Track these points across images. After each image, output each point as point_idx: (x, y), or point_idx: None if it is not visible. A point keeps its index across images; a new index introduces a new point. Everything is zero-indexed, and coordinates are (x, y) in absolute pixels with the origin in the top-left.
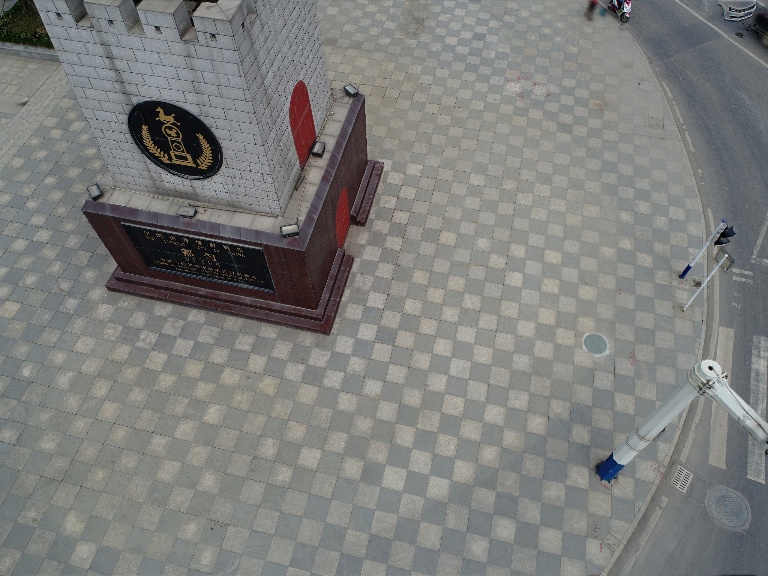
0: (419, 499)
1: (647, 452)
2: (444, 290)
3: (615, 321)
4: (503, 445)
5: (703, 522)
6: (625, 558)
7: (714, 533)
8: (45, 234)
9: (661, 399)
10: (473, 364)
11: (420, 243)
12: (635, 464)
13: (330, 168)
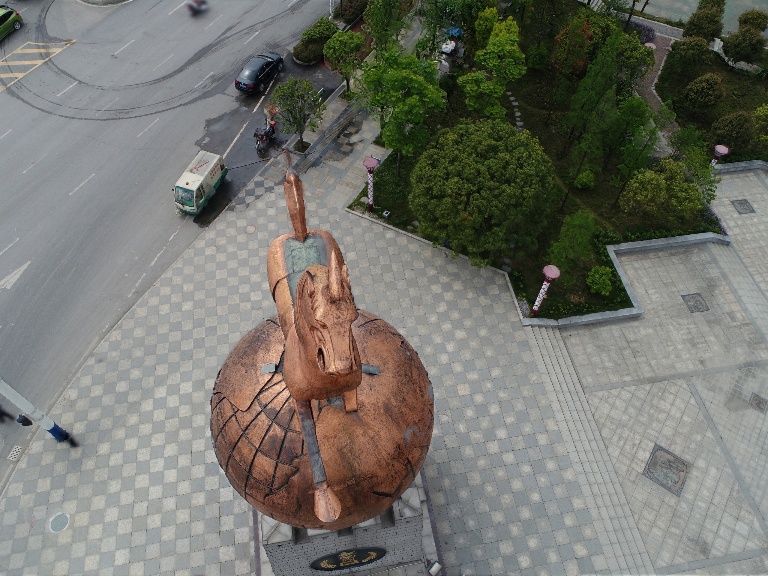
0: (170, 383)
1: (34, 458)
2: (177, 523)
3: (42, 550)
4: (125, 428)
5: (8, 433)
6: (57, 399)
7: (3, 429)
8: (493, 449)
9: (18, 498)
10: (148, 471)
11: (205, 562)
12: (43, 448)
13: (255, 509)
